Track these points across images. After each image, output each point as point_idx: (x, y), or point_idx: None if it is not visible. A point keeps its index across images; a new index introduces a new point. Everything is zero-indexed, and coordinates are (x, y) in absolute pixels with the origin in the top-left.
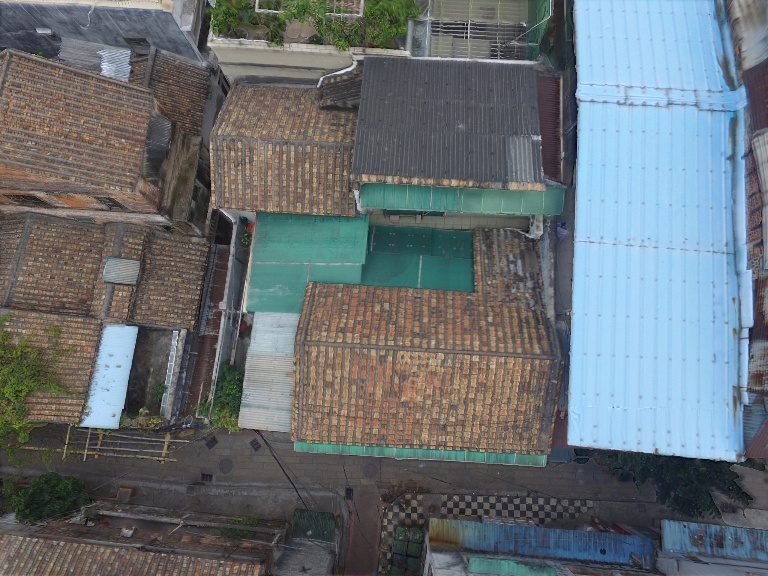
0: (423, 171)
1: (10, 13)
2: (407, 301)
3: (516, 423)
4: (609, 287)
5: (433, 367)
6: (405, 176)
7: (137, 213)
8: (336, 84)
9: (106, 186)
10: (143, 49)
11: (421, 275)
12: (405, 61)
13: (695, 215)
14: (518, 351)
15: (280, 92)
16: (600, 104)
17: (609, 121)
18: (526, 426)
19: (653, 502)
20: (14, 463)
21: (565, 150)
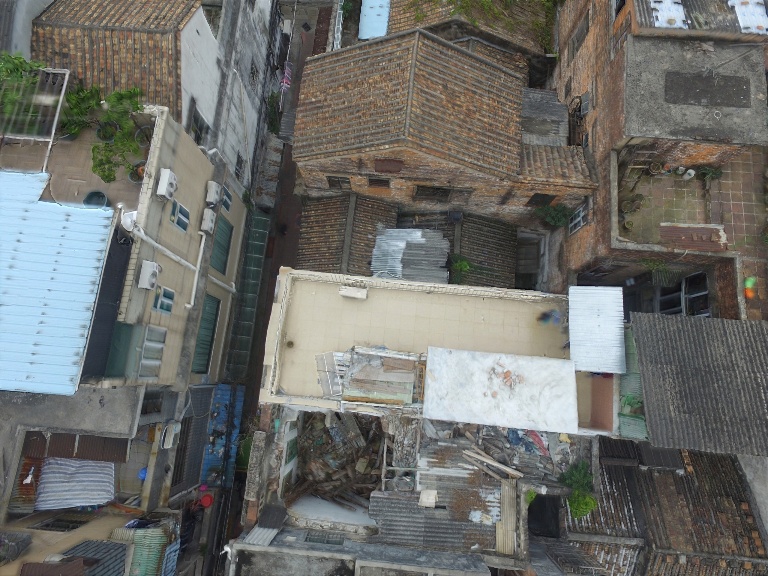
0: None
1: None
2: None
3: None
4: None
5: None
6: None
7: None
8: None
9: None
10: None
11: None
12: None
13: None
14: None
15: None
16: None
17: None
18: None
19: None
20: None
21: None
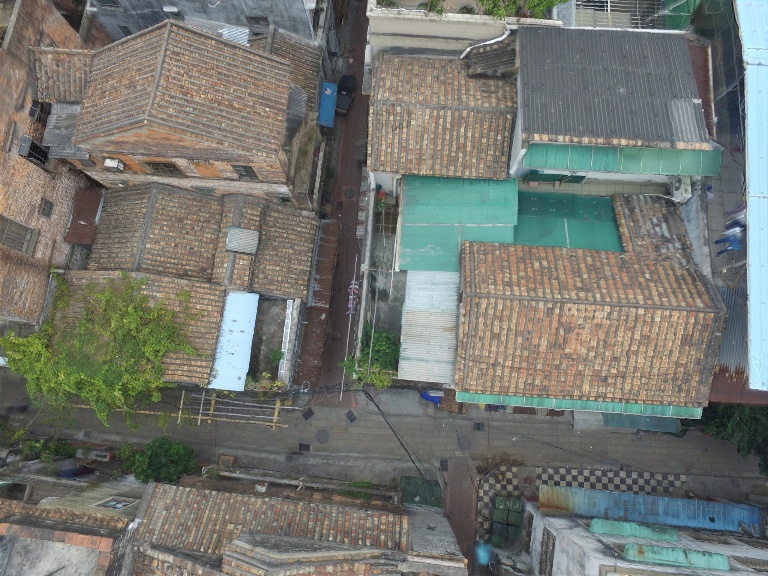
0: (592, 131)
1: None
2: (564, 259)
3: (676, 375)
4: None
5: (599, 319)
6: (575, 136)
7: (264, 183)
8: (486, 54)
9: (254, 152)
10: (260, 28)
11: (569, 237)
12: (559, 30)
13: None
14: (682, 305)
15: (426, 62)
16: (767, 67)
17: None
18: (686, 378)
19: (746, 477)
20: (131, 426)
21: (719, 115)
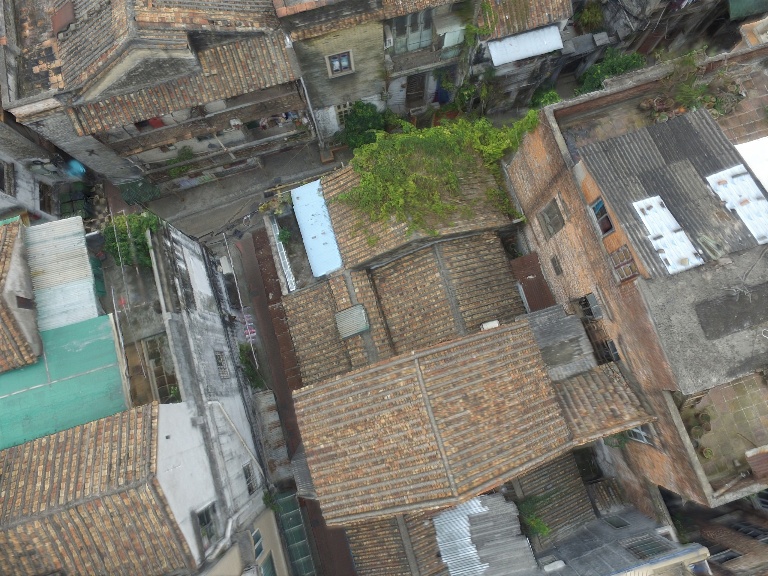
0: None
1: (590, 571)
2: None
3: None
4: None
5: None
6: None
7: None
8: None
9: (312, 386)
10: None
11: None
12: None
13: None
14: None
15: (128, 575)
16: None
17: None
18: None
19: None
20: None
21: None
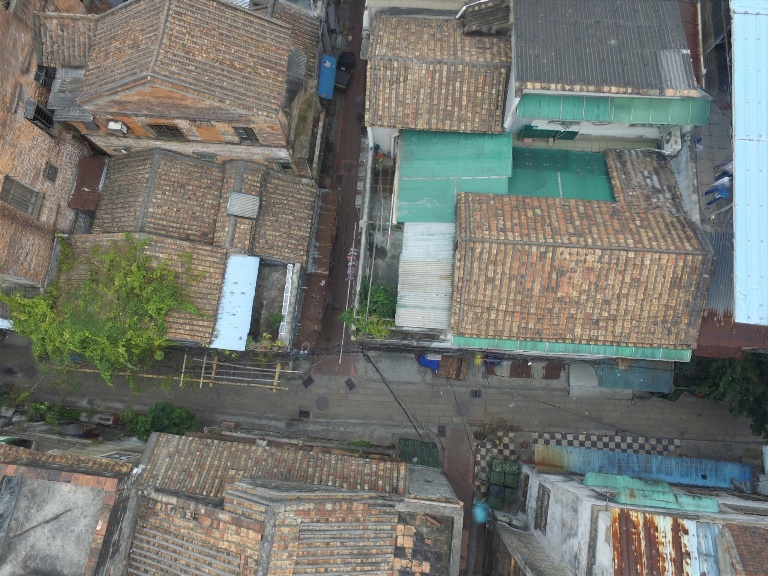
0: (583, 80)
1: None
2: (557, 208)
3: (666, 318)
4: None
5: (590, 263)
6: (567, 84)
7: (265, 147)
8: (481, 11)
9: (255, 111)
10: None
11: (562, 189)
12: None
13: None
14: (671, 248)
15: (422, 22)
16: (754, 16)
17: (763, 31)
18: (675, 321)
19: (739, 442)
20: (134, 390)
21: (708, 67)
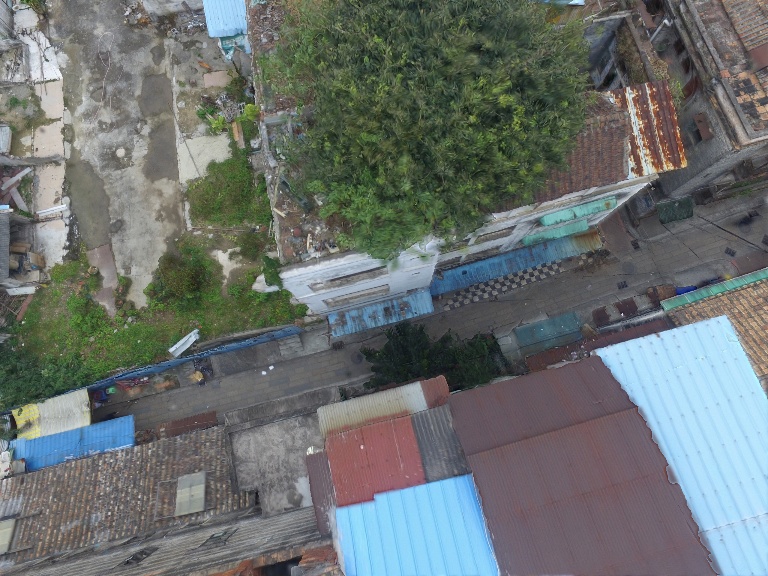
0: None
1: None
2: None
3: None
4: (764, 463)
5: None
6: None
7: None
8: None
9: None
10: None
11: None
12: None
13: (723, 571)
14: (765, 381)
15: None
16: None
17: None
18: None
19: None
20: None
21: None
